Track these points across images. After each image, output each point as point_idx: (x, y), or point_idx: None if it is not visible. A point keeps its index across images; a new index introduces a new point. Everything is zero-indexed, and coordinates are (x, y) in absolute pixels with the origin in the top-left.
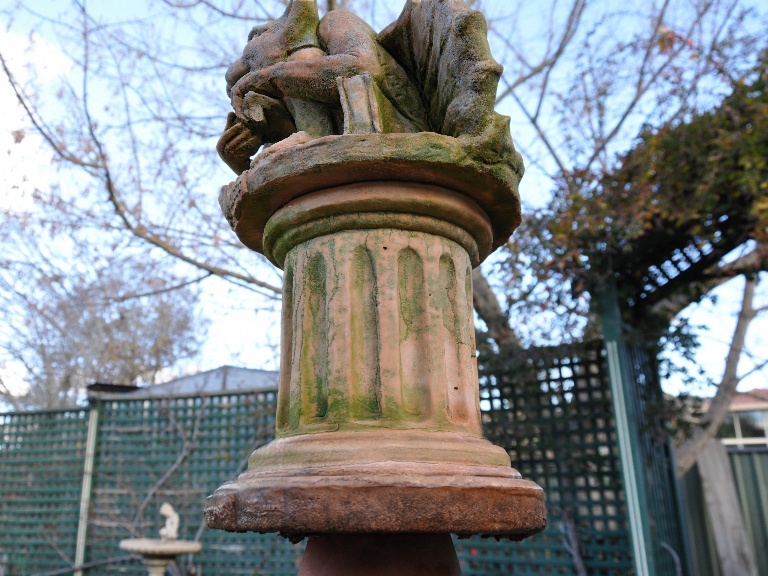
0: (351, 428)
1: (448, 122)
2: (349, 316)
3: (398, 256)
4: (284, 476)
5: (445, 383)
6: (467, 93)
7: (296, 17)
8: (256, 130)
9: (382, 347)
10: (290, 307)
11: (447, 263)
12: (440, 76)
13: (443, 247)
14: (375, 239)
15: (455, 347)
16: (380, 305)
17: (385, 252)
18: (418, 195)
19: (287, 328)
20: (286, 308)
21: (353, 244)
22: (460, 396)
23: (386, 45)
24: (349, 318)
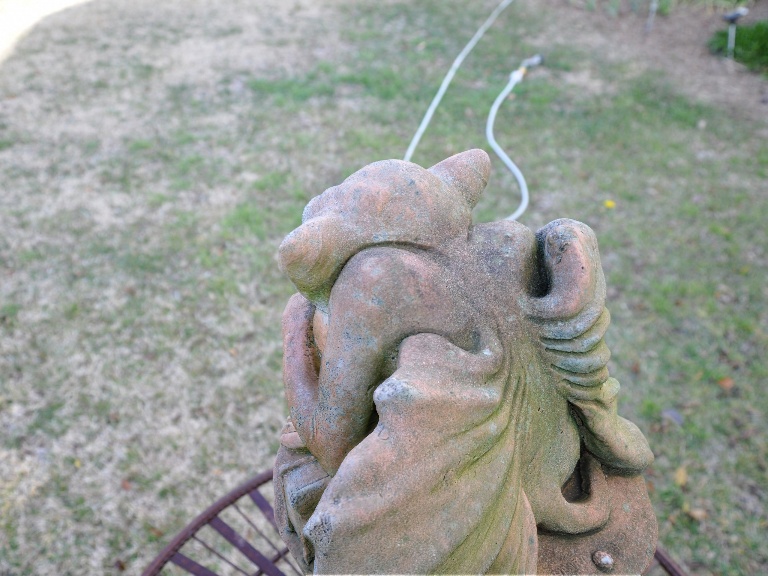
0: None
1: None
2: None
3: None
4: None
5: None
6: None
7: None
8: None
9: None
10: None
11: None
12: None
13: None
14: None
15: None
16: None
17: None
18: None
19: None
20: None
21: None
22: None
23: None
24: None
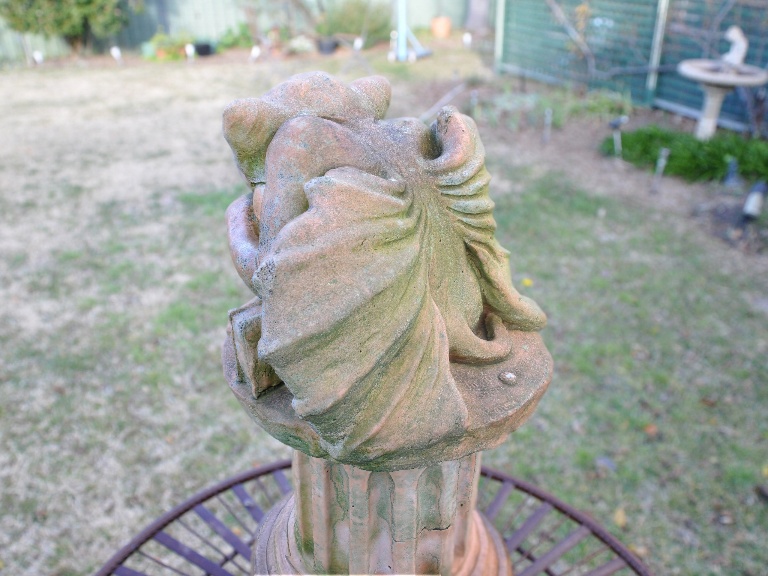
0: (290, 567)
1: None
2: (299, 485)
3: (326, 464)
4: (253, 570)
5: (367, 569)
6: None
7: (236, 157)
8: None
9: (314, 526)
10: None
11: (387, 472)
12: None
13: None
14: None
15: (391, 540)
16: (312, 496)
17: None
18: None
19: None
20: None
21: None
22: (392, 574)
23: None
24: (299, 487)
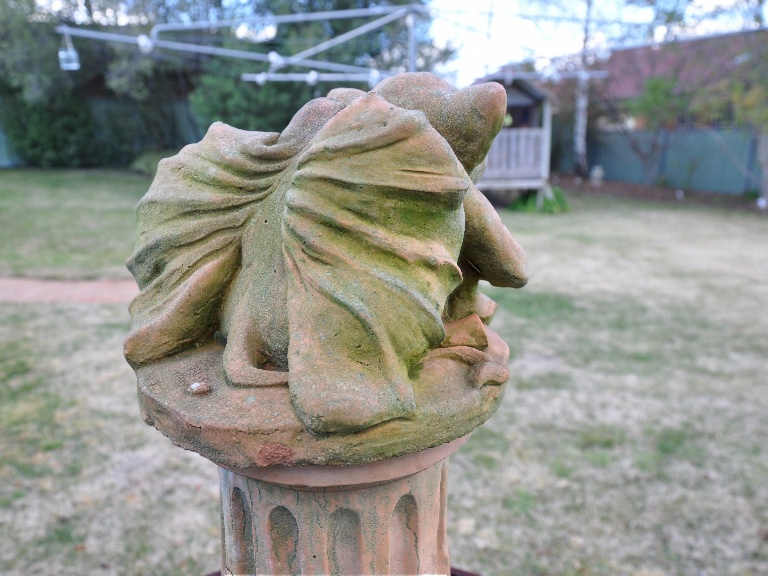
0: None
1: None
2: None
3: None
4: None
5: None
6: None
7: None
8: None
9: None
10: None
11: None
12: None
13: None
14: None
15: None
16: None
17: None
18: None
19: None
20: None
21: None
22: None
23: None
24: None
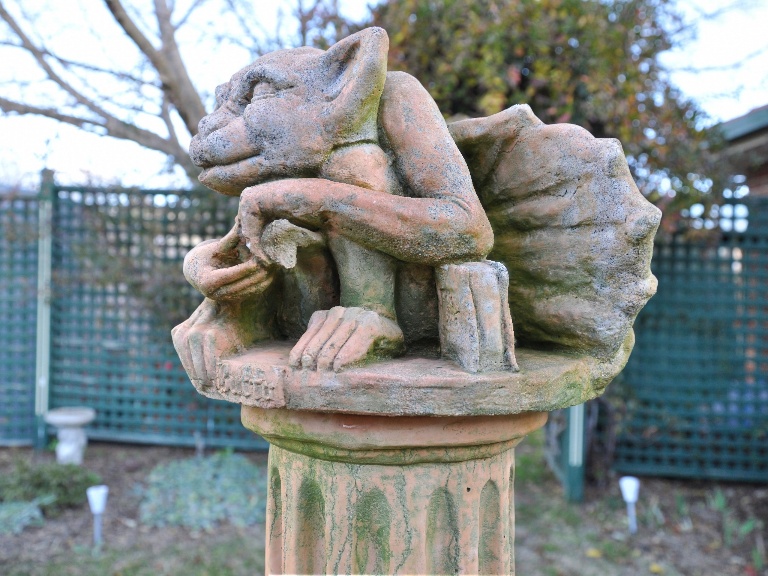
0: None
1: (564, 325)
2: None
3: None
4: None
5: None
6: (615, 313)
7: (362, 98)
8: (272, 268)
9: None
10: (304, 531)
11: None
12: (553, 245)
13: (510, 460)
14: (458, 478)
15: None
16: (463, 572)
17: (469, 495)
18: (522, 428)
19: (302, 563)
20: (300, 533)
21: (431, 486)
22: None
23: (460, 148)
24: None
